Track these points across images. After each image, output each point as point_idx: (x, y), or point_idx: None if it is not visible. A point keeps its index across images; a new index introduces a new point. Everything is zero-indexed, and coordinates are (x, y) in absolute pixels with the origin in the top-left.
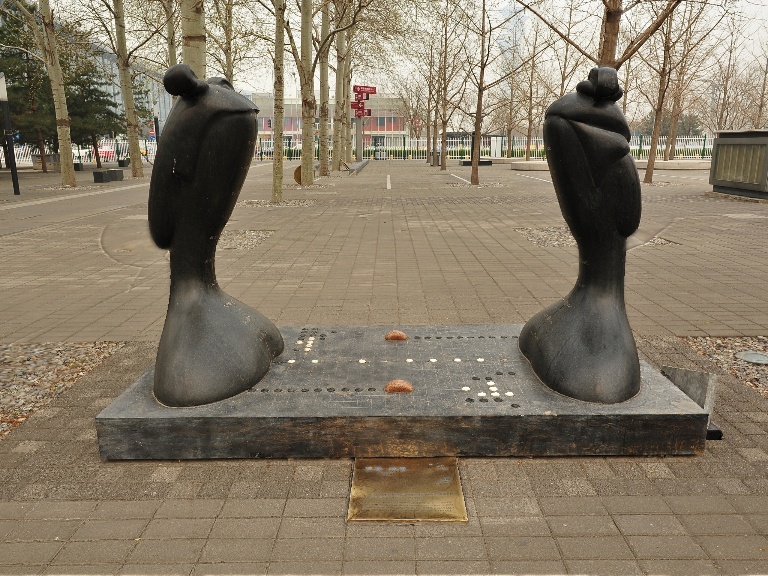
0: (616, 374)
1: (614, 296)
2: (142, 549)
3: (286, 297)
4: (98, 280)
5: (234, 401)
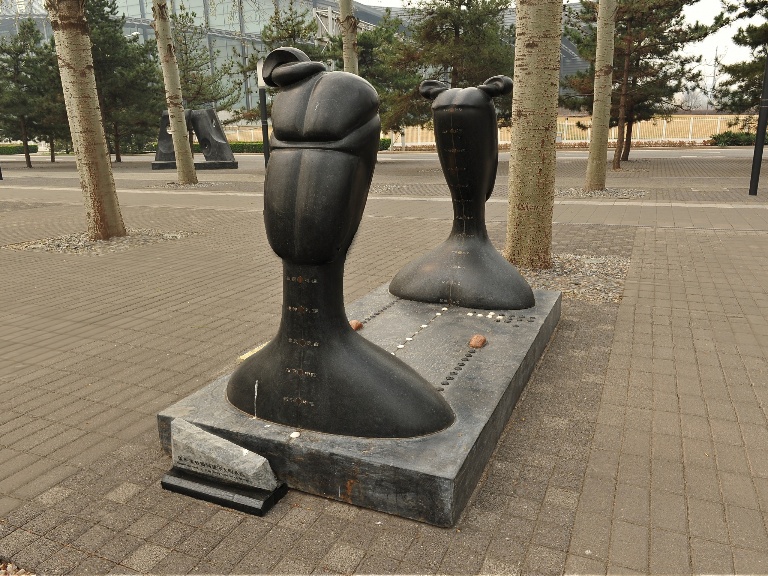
0: None
1: None
2: None
3: None
4: None
5: None
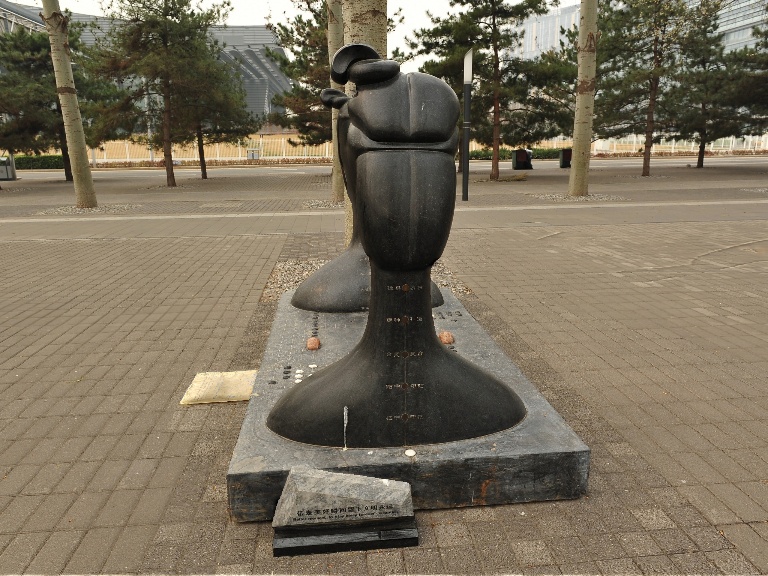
0: (283, 401)
1: (363, 338)
2: (200, 339)
3: (654, 315)
4: (625, 262)
5: (299, 311)
